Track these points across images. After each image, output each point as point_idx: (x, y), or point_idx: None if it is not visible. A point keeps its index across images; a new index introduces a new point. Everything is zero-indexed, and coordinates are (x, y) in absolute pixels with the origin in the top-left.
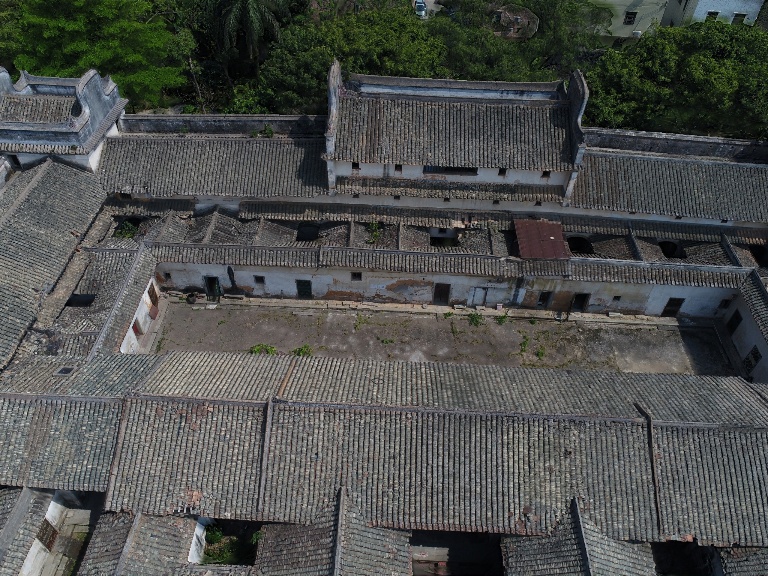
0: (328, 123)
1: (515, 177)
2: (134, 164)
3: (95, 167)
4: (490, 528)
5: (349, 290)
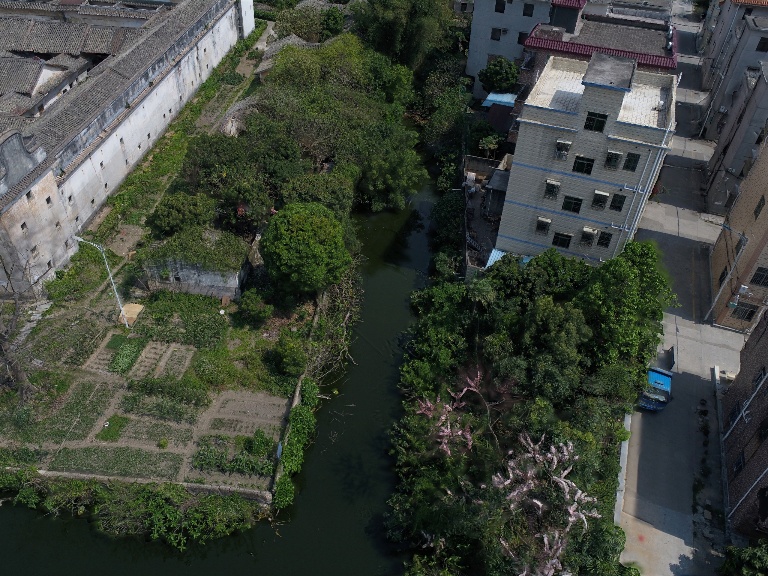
0: None
1: None
2: None
3: None
4: None
5: None
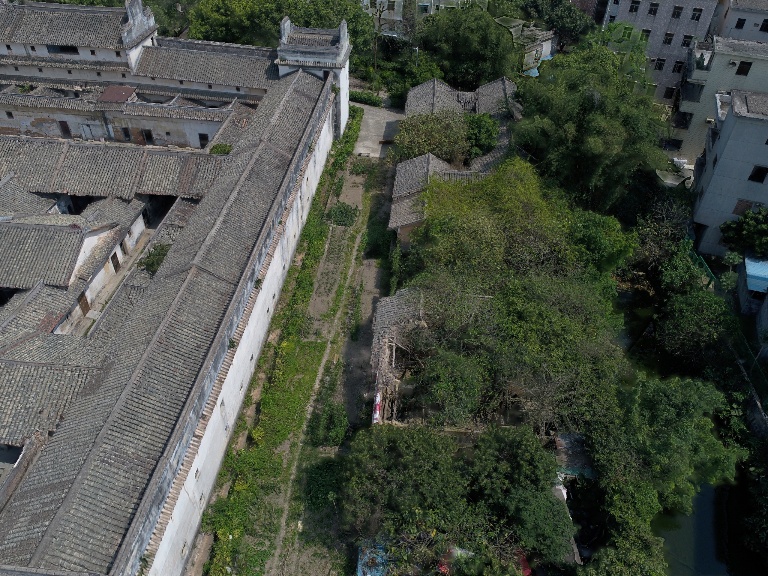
0: None
1: (102, 56)
2: None
3: None
4: None
5: (10, 126)
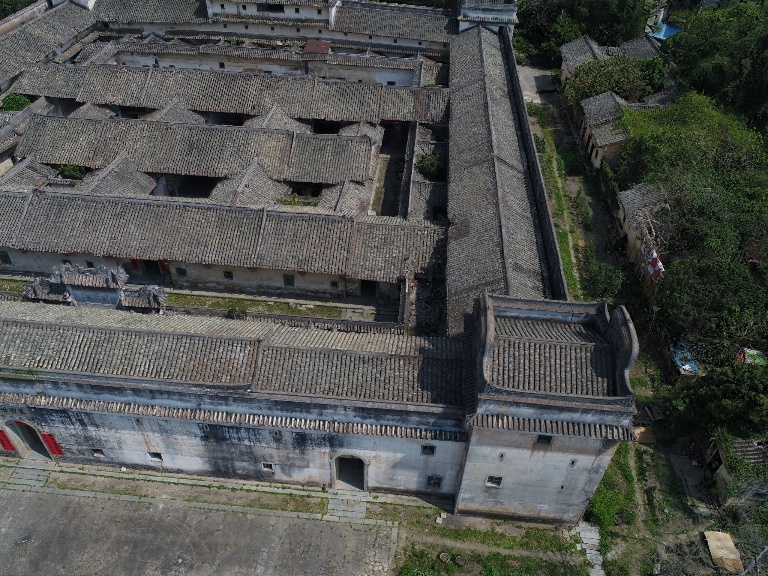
0: None
1: (304, 14)
2: (111, 8)
3: (91, 8)
4: (237, 111)
5: None
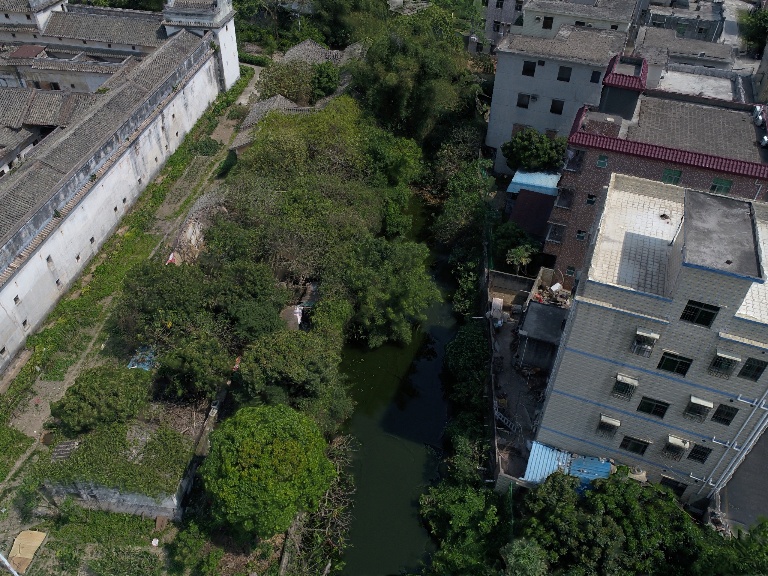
0: None
1: (15, 19)
2: None
3: None
4: None
5: None
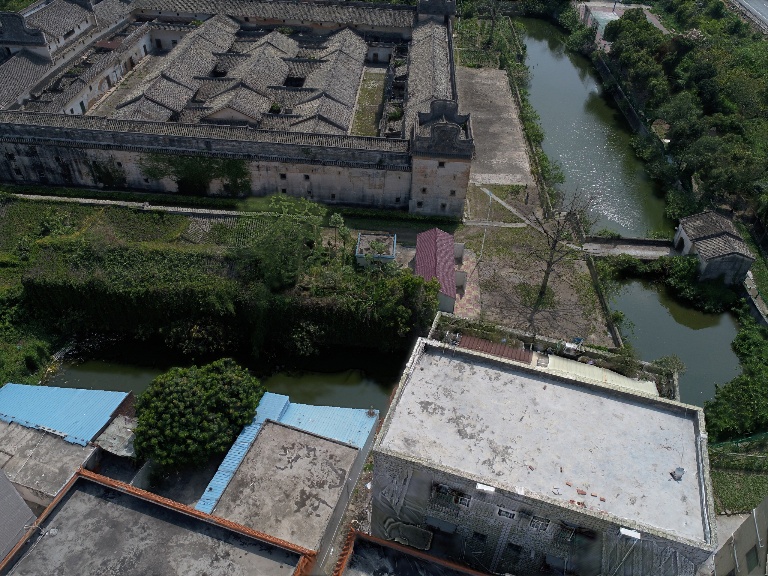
0: (39, 28)
1: (82, 28)
2: None
3: None
4: (214, 66)
5: None
